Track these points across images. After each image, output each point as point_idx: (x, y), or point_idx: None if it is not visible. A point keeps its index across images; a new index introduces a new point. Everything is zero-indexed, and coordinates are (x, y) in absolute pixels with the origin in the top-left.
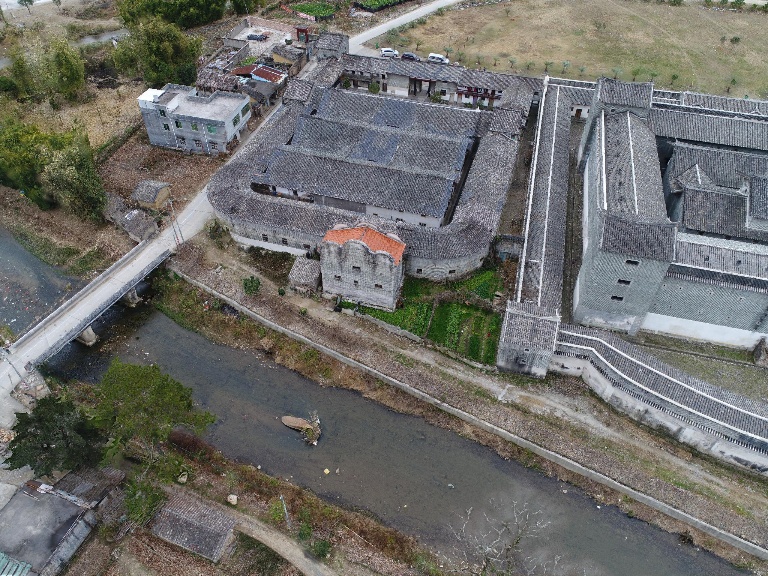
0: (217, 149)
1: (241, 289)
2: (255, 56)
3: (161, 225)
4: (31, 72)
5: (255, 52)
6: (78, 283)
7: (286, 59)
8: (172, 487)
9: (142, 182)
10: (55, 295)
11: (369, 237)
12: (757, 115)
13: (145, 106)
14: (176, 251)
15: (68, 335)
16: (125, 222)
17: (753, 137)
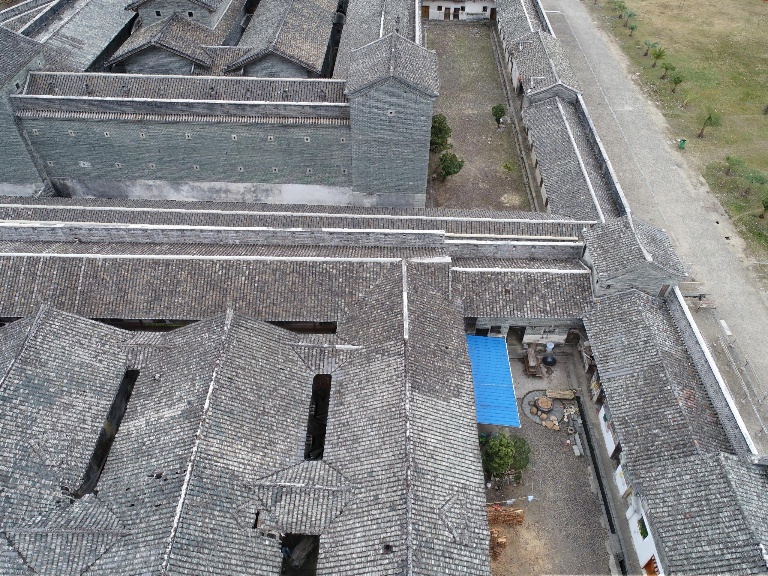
0: None
1: None
2: None
3: None
4: None
5: None
6: None
7: None
8: None
9: None
10: None
11: None
12: (416, 8)
13: None
14: None
15: None
16: None
17: (361, 7)
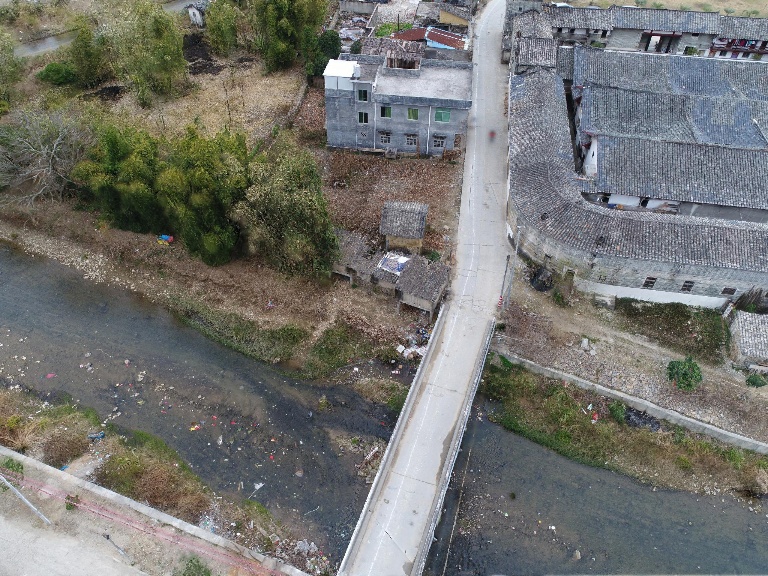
0: (442, 146)
1: (649, 378)
2: (388, 22)
3: None
4: (117, 49)
5: (387, 17)
6: (334, 393)
7: (459, 18)
8: None
9: (389, 205)
10: (307, 422)
11: None
12: None
13: (335, 86)
14: (501, 319)
15: None
16: (382, 275)
17: None
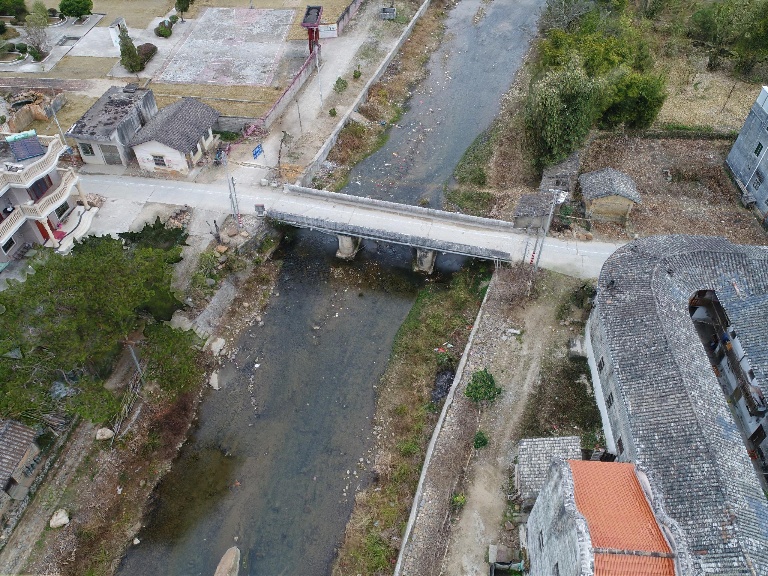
0: None
1: None
2: None
3: (562, 231)
4: (723, 8)
5: None
6: (436, 207)
7: None
8: (94, 426)
9: (614, 171)
10: (408, 197)
11: (639, 574)
12: None
13: (762, 103)
14: (516, 265)
15: (317, 221)
16: None
17: None
